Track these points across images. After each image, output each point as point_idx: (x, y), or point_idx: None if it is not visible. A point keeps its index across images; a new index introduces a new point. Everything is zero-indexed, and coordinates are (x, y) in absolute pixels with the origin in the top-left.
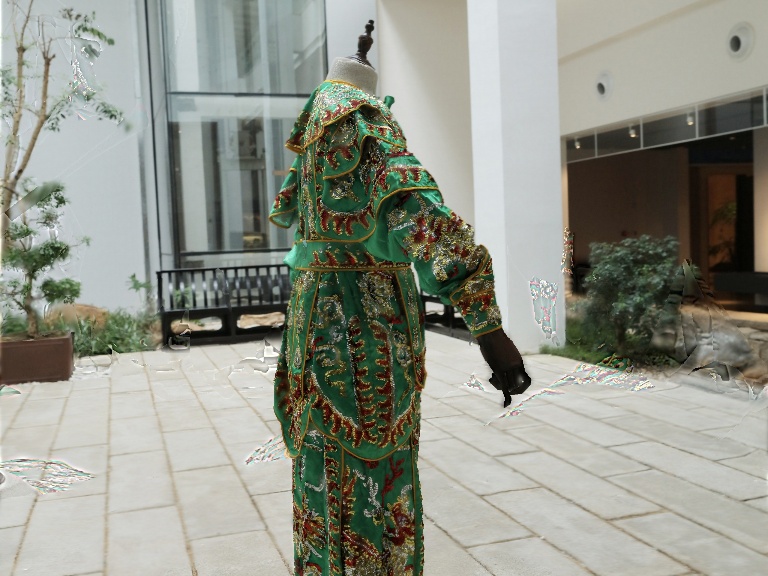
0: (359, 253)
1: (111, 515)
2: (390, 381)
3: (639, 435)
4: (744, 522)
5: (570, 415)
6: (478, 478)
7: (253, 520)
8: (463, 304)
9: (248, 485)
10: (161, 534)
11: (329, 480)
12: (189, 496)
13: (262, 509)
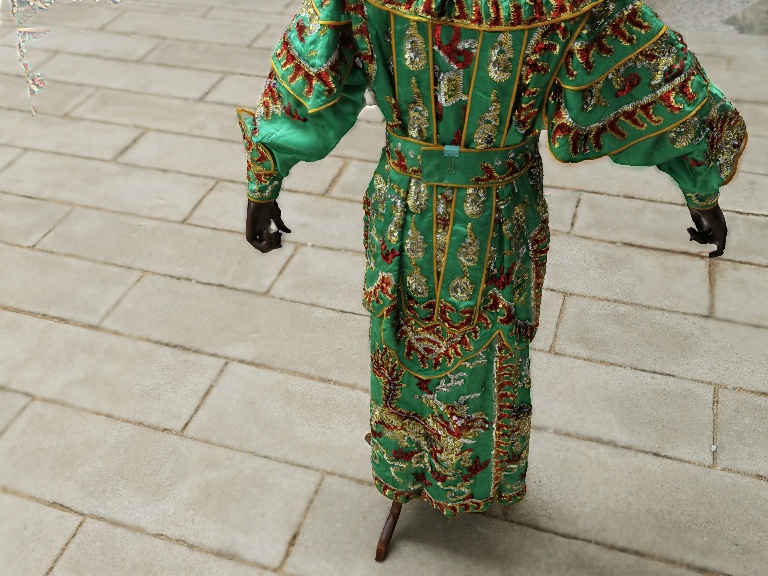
0: (532, 147)
1: None
2: None
3: (207, 70)
4: None
5: (104, 64)
6: (147, 199)
7: None
8: None
9: None
10: None
11: (501, 382)
12: None
13: None
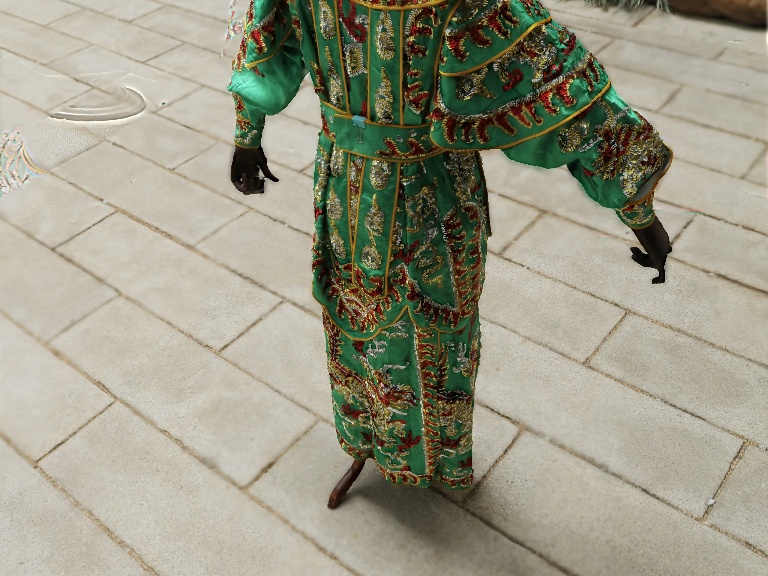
0: None
1: None
2: (479, 253)
3: None
4: None
5: None
6: (279, 146)
7: (93, 286)
8: None
9: (34, 233)
10: (3, 346)
11: (423, 360)
12: None
13: (87, 266)
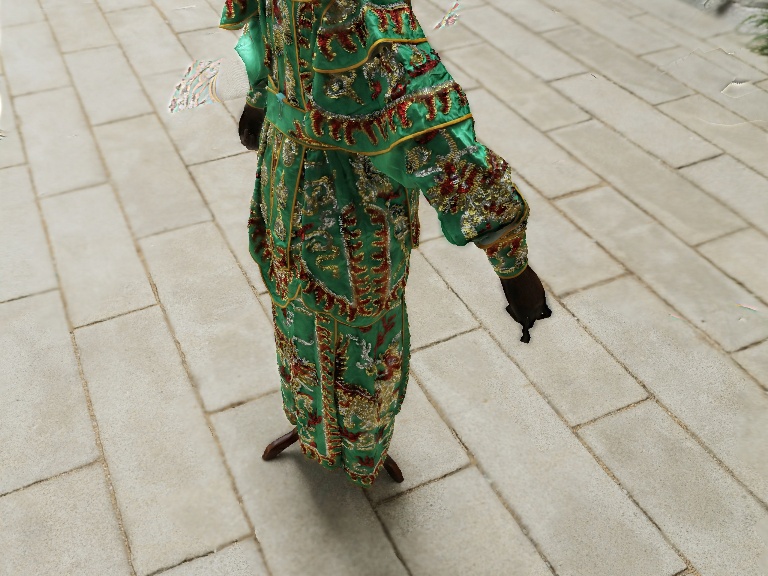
0: None
1: (42, 200)
2: (387, 259)
3: (580, 62)
4: (677, 202)
5: (509, 26)
6: None
7: (197, 206)
8: (489, 249)
9: (180, 149)
10: (105, 230)
11: (321, 343)
12: (120, 168)
13: (203, 188)
